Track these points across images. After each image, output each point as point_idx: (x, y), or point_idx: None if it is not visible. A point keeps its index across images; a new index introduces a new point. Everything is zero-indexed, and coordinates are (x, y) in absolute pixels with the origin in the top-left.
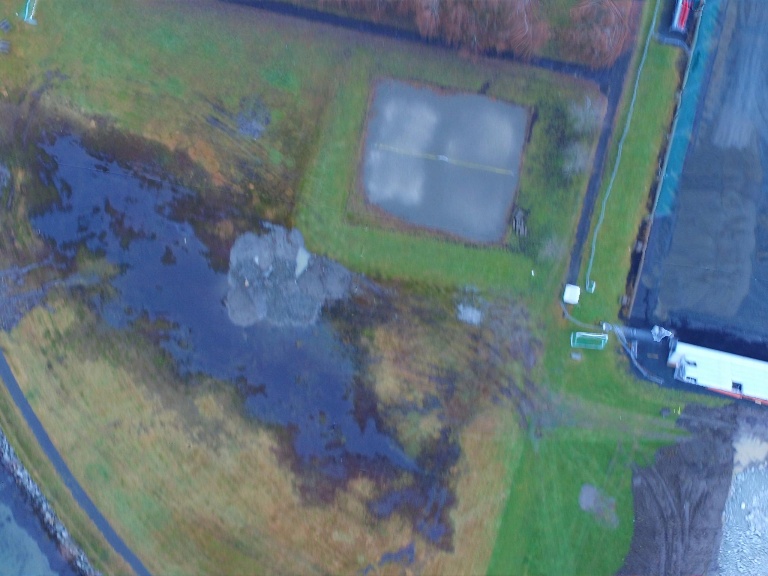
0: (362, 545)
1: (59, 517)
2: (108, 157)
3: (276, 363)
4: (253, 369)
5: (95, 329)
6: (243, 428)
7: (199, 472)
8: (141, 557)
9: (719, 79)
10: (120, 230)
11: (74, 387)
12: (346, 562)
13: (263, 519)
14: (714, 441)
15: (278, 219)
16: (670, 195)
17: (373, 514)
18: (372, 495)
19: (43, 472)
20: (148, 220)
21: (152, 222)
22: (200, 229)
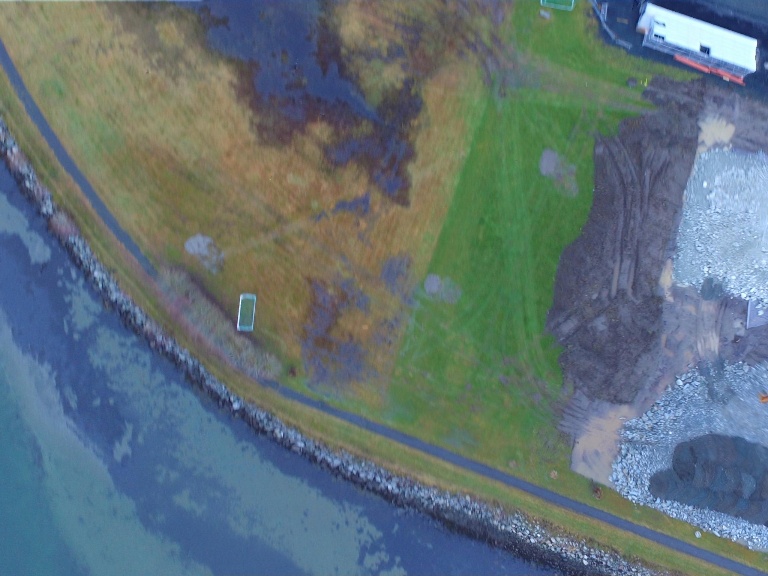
0: (317, 190)
1: (10, 130)
2: None
3: None
4: None
5: None
6: (203, 59)
7: (156, 100)
8: (91, 180)
9: None
10: None
11: None
12: (299, 206)
13: (218, 154)
14: (679, 113)
15: None
16: None
17: (330, 160)
18: (330, 140)
19: None
20: None
21: None
22: None
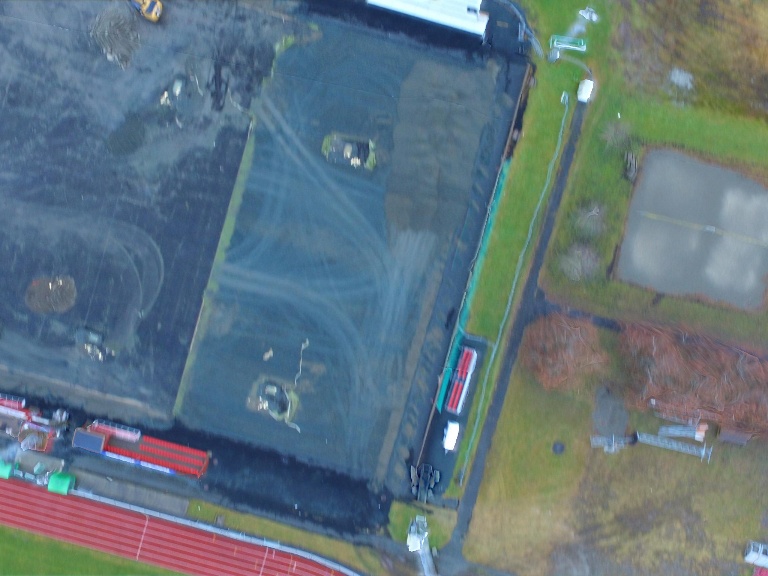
0: None
1: None
2: None
3: None
4: None
5: None
6: None
7: None
8: None
9: (427, 300)
10: None
11: None
12: None
13: None
14: None
15: None
16: (481, 186)
17: None
18: None
19: None
20: None
21: None
22: None
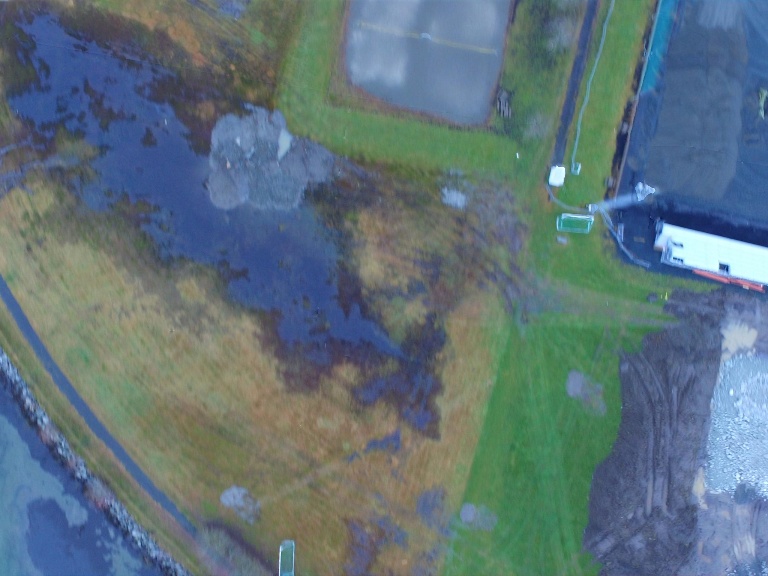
0: (347, 432)
1: (39, 402)
2: (87, 36)
3: (259, 247)
4: (235, 253)
5: (75, 211)
6: (226, 313)
7: (181, 357)
8: (123, 443)
9: None
10: (99, 111)
11: (54, 270)
12: (331, 449)
13: (247, 405)
14: (702, 326)
15: (260, 100)
16: (655, 76)
17: (358, 401)
18: (357, 381)
19: (23, 356)
20: (128, 101)
21: (132, 103)
22: (181, 110)
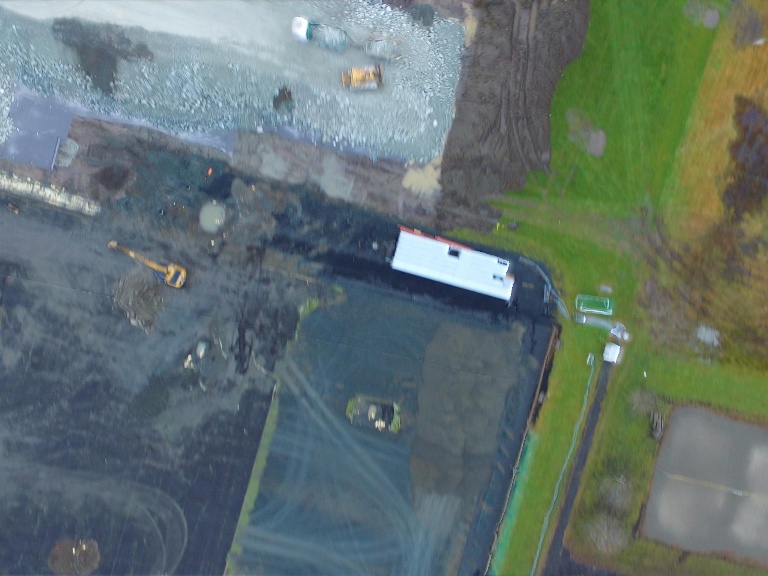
0: None
1: None
2: None
3: None
4: None
5: None
6: None
7: None
8: None
9: (452, 562)
10: None
11: None
12: None
13: None
14: (467, 194)
15: None
16: (507, 448)
17: None
18: None
19: None
20: None
21: None
22: None
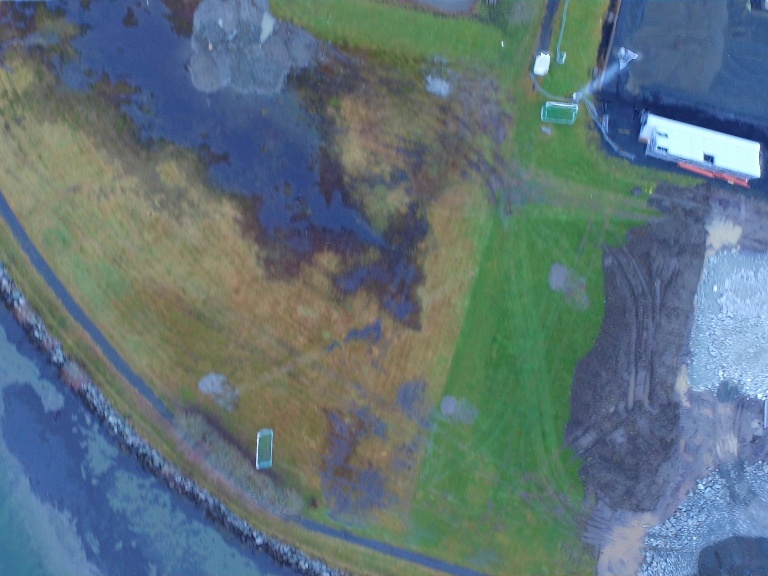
0: (327, 320)
1: (16, 282)
2: None
3: (240, 131)
4: (216, 136)
5: (54, 90)
6: (206, 197)
7: (160, 241)
8: (100, 327)
9: None
10: None
11: (32, 149)
12: (311, 338)
13: (226, 291)
14: (686, 220)
15: None
16: None
17: (339, 289)
18: (338, 269)
19: None
20: None
21: None
22: None
